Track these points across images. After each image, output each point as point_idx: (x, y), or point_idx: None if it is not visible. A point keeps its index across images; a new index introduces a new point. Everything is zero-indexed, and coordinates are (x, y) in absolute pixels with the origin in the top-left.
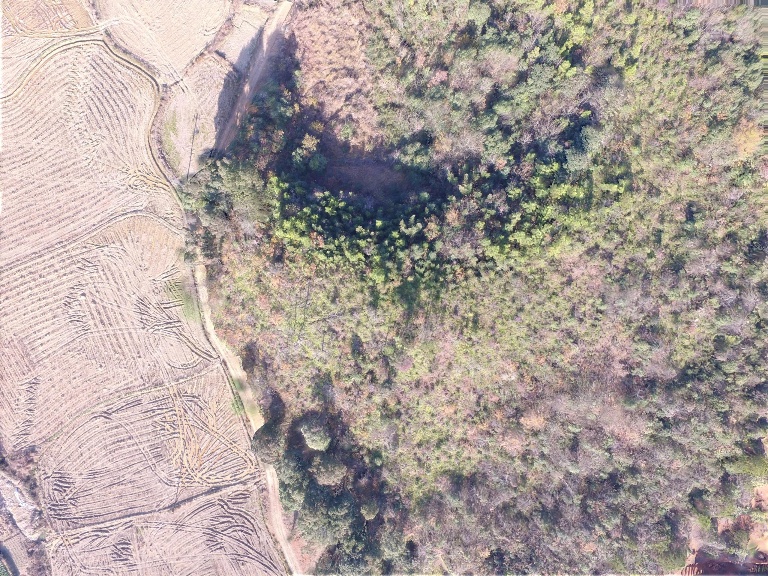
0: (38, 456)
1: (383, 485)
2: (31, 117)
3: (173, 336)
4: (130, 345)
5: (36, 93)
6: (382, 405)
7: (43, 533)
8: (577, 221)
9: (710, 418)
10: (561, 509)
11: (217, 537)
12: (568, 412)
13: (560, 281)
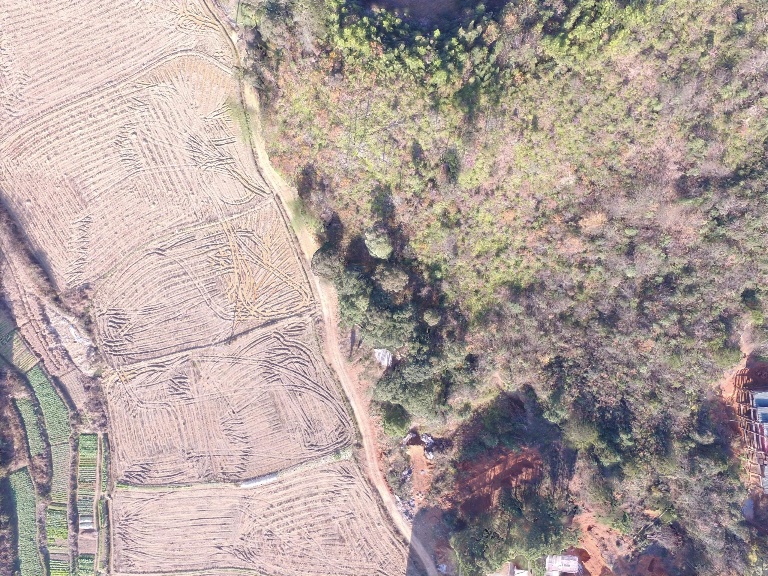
0: (92, 293)
1: (443, 299)
2: None
3: (226, 173)
4: (183, 182)
5: None
6: (443, 214)
7: (99, 369)
8: (633, 21)
9: (763, 212)
10: (618, 313)
11: (274, 369)
12: (625, 215)
13: (617, 82)
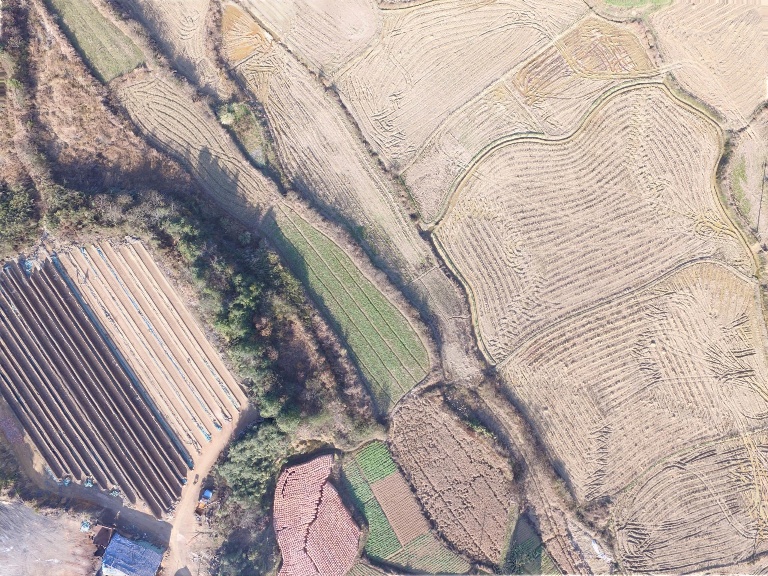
0: (614, 507)
1: None
2: (592, 160)
3: (746, 385)
4: (703, 394)
5: (597, 135)
6: None
7: None
8: None
9: None
10: None
11: None
12: None
13: None
